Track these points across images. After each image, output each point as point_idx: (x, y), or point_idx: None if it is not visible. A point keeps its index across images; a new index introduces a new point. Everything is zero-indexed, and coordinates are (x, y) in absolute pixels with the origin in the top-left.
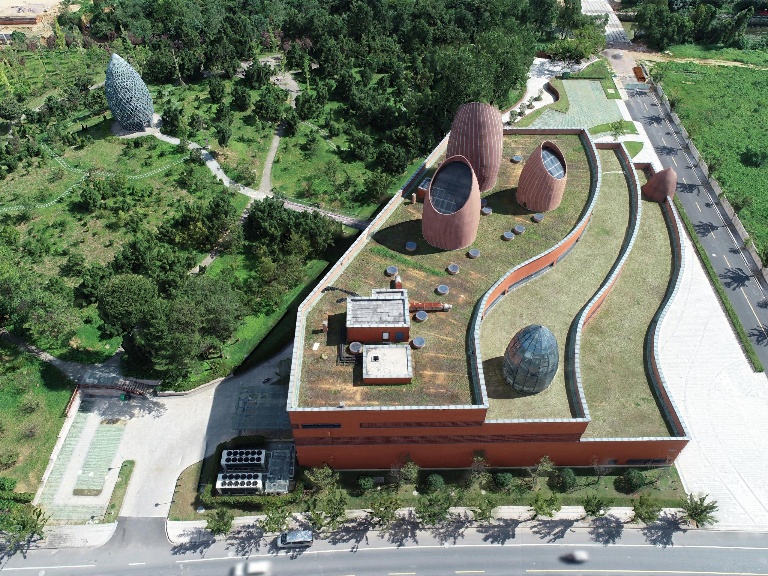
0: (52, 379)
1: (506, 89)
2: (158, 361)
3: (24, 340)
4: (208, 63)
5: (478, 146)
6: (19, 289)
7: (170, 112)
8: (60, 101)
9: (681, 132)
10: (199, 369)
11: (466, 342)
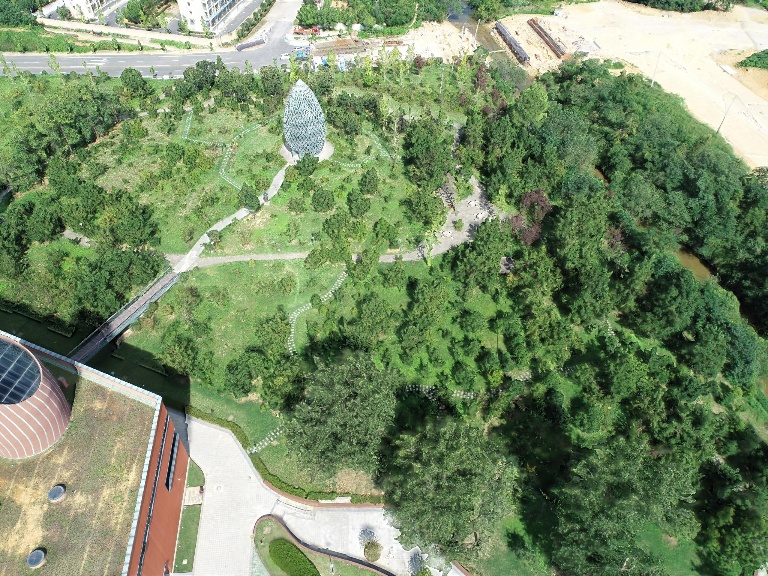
0: None
1: None
2: None
3: None
4: None
5: None
6: None
7: (303, 158)
8: (349, 101)
9: None
10: None
11: None
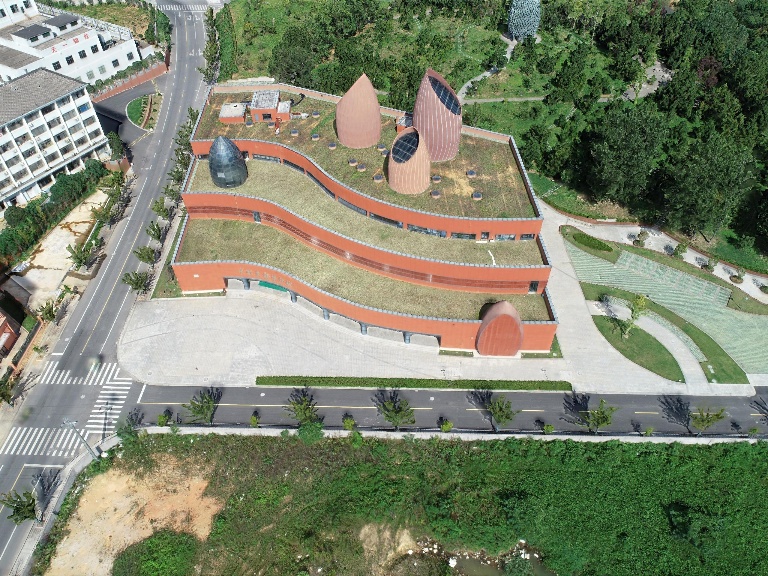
0: None
1: None
2: None
3: None
4: None
5: None
6: None
7: (527, 38)
8: None
9: None
10: None
11: None
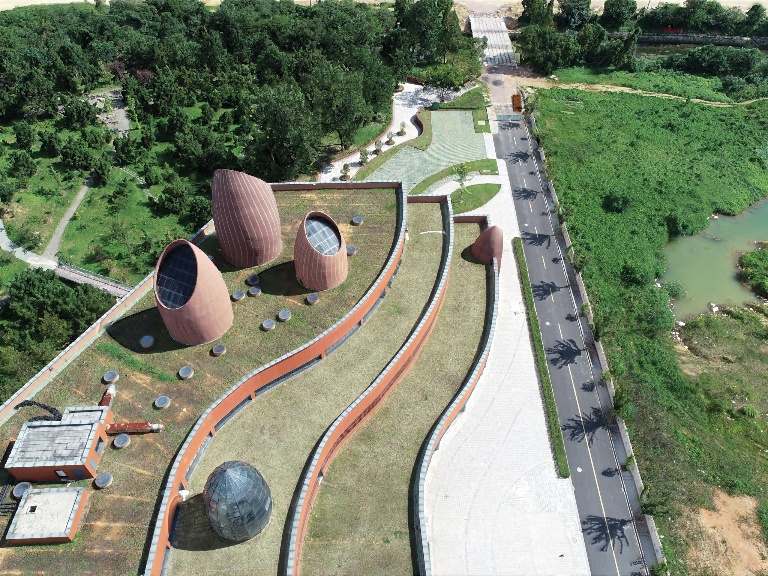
0: None
1: (346, 129)
2: None
3: None
4: (21, 102)
5: (236, 218)
6: None
7: None
8: None
9: (545, 171)
10: None
11: (164, 477)
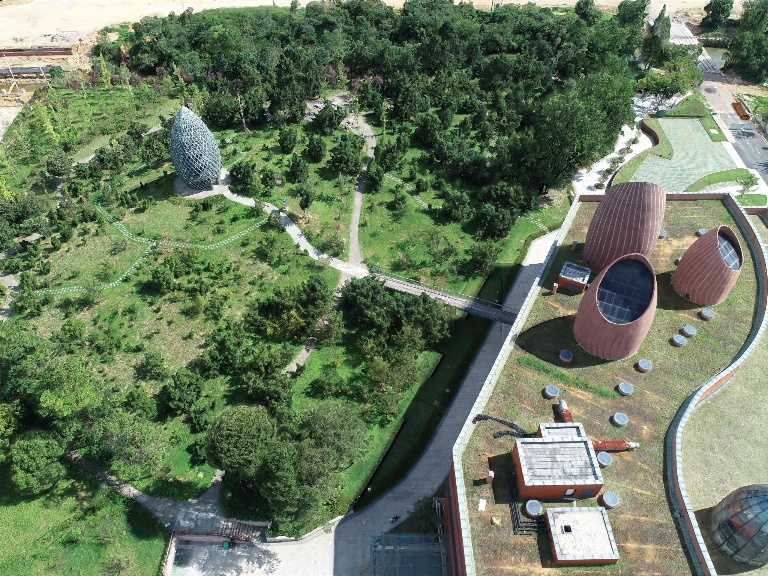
0: (140, 523)
1: (613, 137)
2: (283, 519)
3: (101, 468)
4: (274, 107)
5: (638, 231)
6: (101, 416)
7: (241, 168)
8: (113, 152)
9: None
10: (328, 523)
11: (668, 497)
